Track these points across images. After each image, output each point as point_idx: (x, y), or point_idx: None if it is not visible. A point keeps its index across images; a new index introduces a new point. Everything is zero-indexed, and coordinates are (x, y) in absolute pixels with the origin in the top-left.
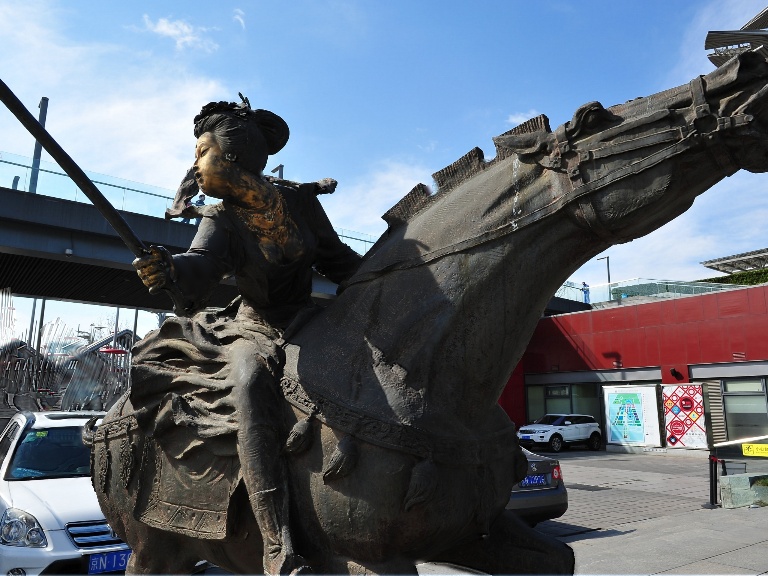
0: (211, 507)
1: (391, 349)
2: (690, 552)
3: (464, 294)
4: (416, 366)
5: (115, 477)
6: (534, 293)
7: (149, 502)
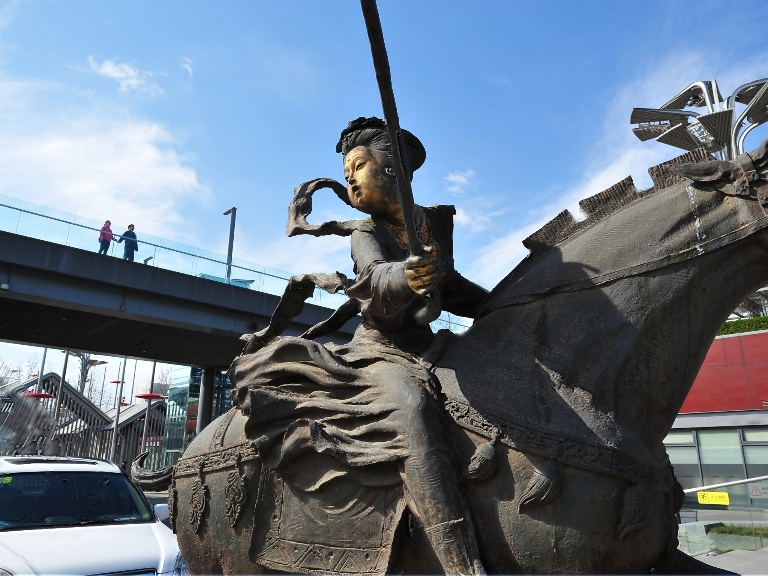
0: (356, 544)
1: (570, 371)
2: None
3: (646, 317)
4: (600, 389)
5: (216, 515)
6: (718, 317)
7: (267, 541)
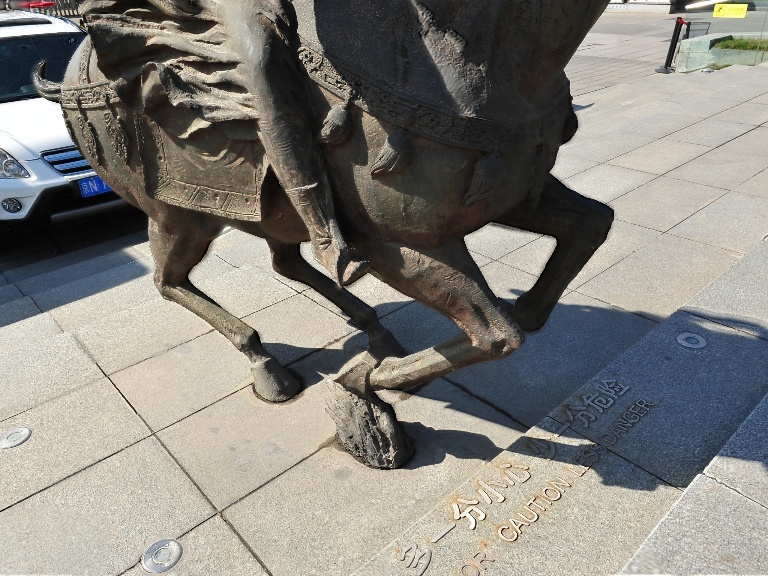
0: (235, 189)
1: (443, 8)
2: (650, 130)
3: None
4: (477, 33)
5: (108, 152)
6: None
7: (159, 180)
